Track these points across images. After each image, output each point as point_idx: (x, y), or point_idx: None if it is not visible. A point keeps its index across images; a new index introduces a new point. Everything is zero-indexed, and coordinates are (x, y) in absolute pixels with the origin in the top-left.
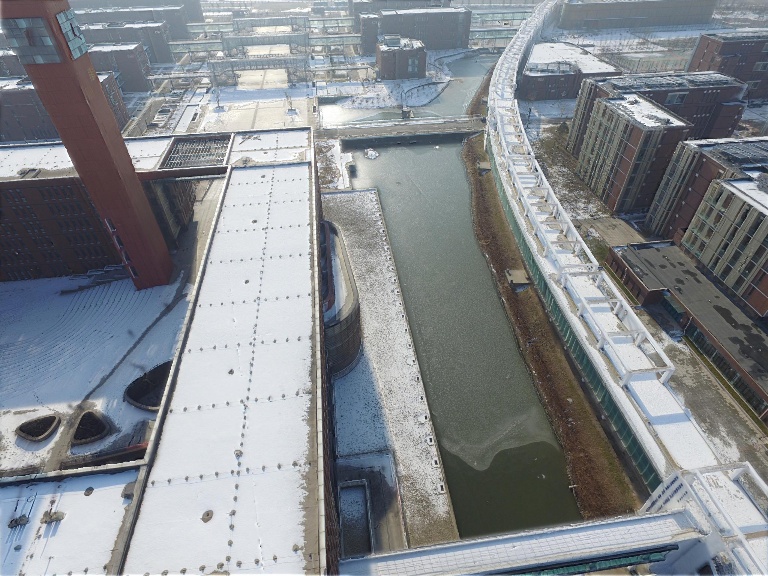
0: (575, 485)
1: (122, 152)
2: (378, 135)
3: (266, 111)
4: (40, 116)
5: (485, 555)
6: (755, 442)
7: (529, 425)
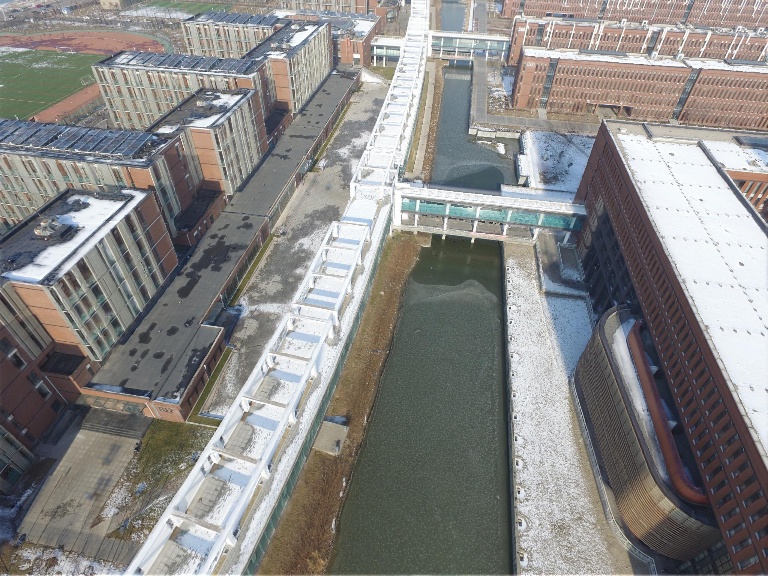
0: (415, 258)
1: None
2: None
3: None
4: None
5: (508, 202)
6: (282, 241)
7: (423, 294)
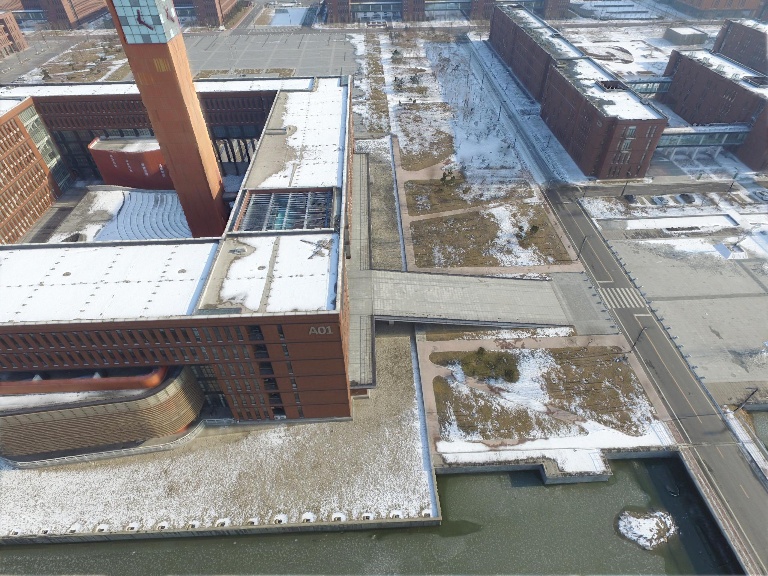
0: None
1: (187, 147)
2: (737, 546)
3: (765, 308)
4: (569, 119)
5: None
6: None
7: None
